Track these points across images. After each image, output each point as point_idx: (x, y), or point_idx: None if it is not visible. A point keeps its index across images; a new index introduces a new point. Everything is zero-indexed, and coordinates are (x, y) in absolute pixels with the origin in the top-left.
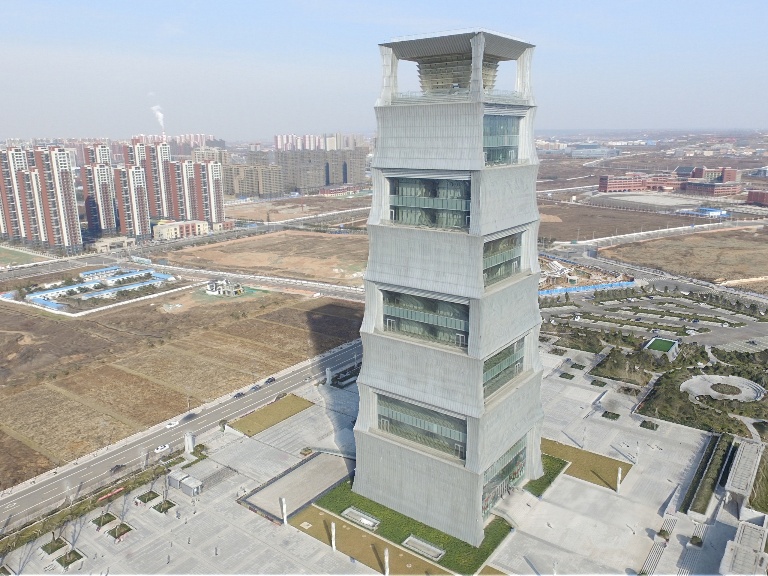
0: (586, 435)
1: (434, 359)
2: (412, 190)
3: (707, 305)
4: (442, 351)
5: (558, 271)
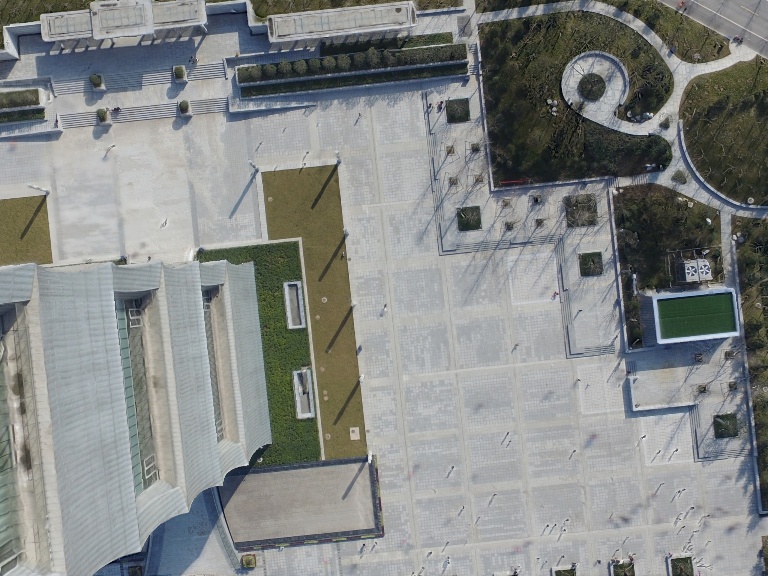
0: None
1: None
2: None
3: None
4: None
5: None
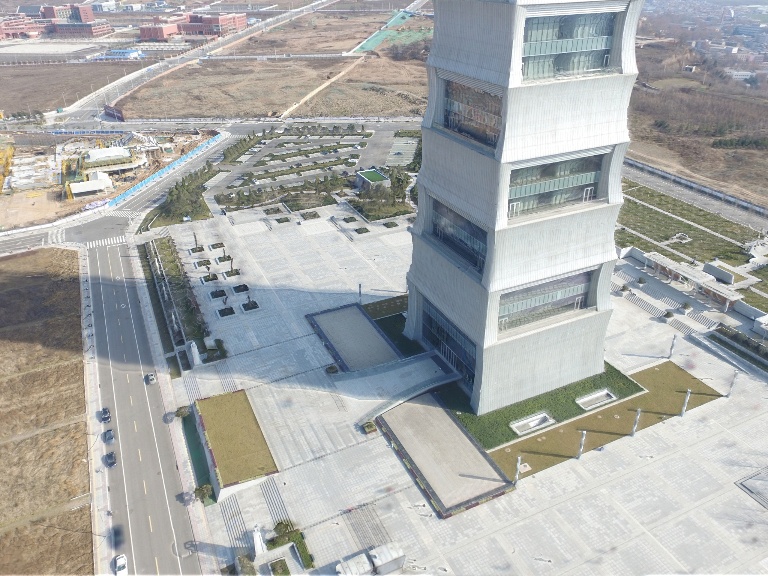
0: None
1: (576, 223)
2: (549, 32)
3: (312, 136)
4: (591, 210)
5: (149, 142)
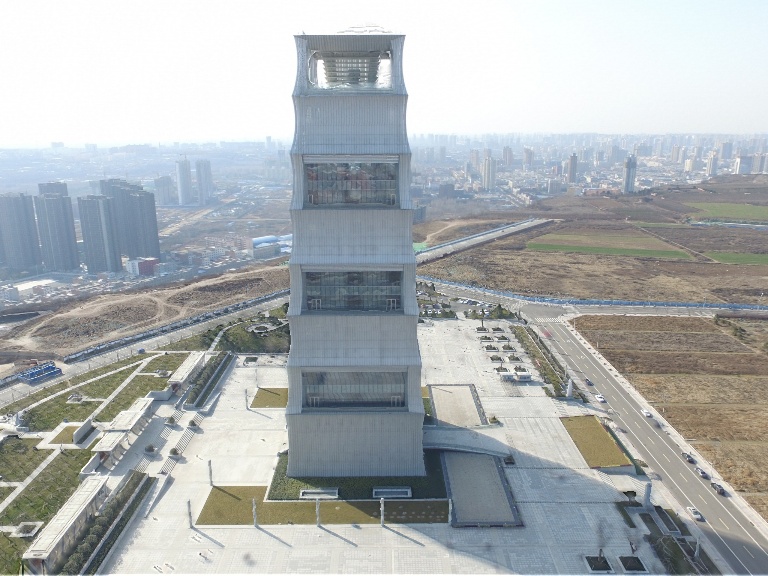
0: (259, 551)
1: None
2: None
3: None
4: None
5: None
